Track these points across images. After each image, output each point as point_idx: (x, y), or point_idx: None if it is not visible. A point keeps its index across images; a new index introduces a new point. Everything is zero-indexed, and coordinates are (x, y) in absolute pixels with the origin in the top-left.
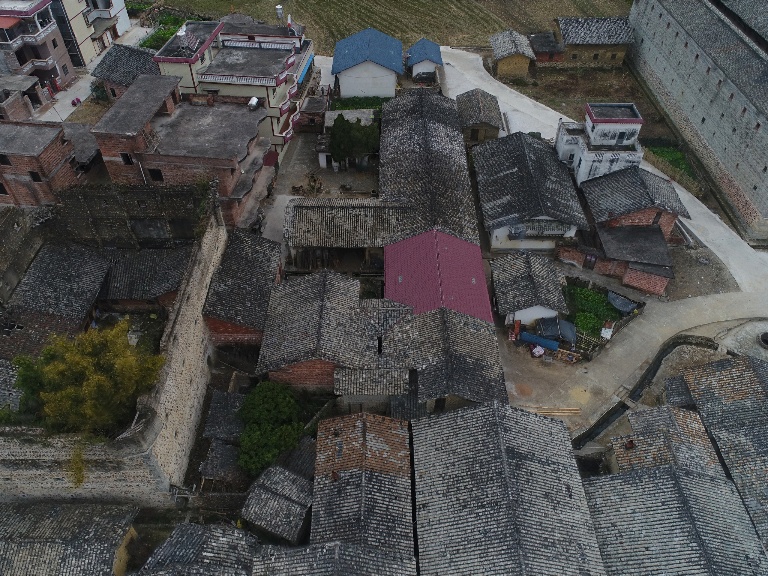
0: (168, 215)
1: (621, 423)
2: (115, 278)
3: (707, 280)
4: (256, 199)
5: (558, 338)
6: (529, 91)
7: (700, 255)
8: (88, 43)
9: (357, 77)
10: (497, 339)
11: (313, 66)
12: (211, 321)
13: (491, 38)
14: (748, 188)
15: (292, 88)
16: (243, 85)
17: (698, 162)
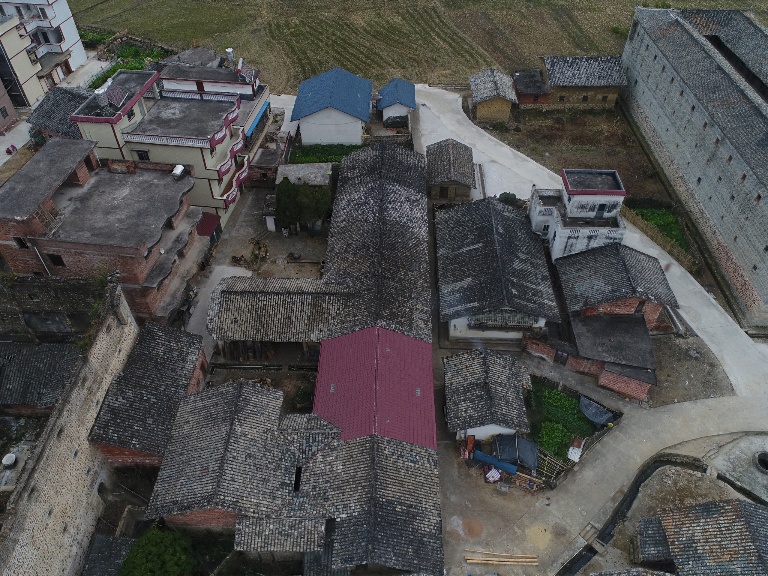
0: (66, 309)
1: (586, 574)
2: (8, 378)
3: (697, 379)
4: (182, 278)
5: (516, 462)
6: (510, 138)
7: (690, 346)
8: (33, 81)
9: (319, 124)
10: (447, 457)
11: (270, 112)
12: (103, 444)
13: (471, 77)
14: (747, 266)
15: (236, 145)
16: (174, 146)
17: (693, 226)
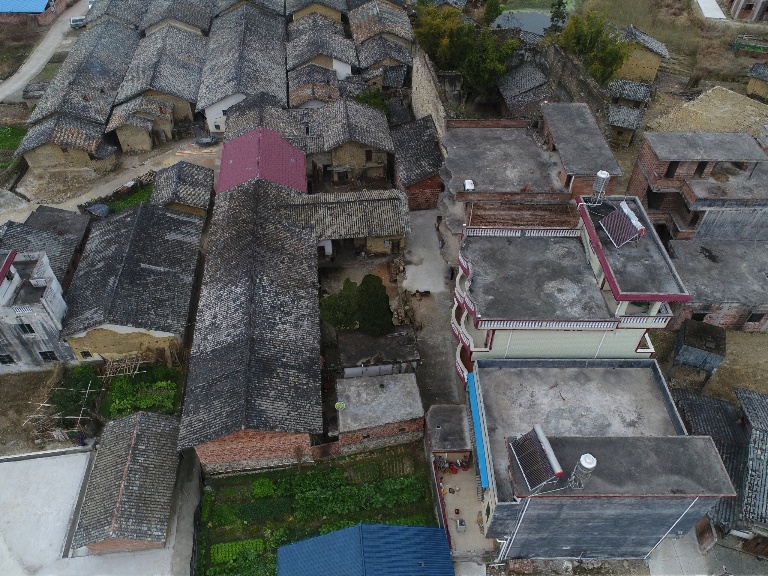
0: None
1: None
2: None
3: None
4: None
5: None
6: None
7: None
8: None
9: None
10: None
11: None
12: None
13: None
14: None
15: None
16: None
17: None
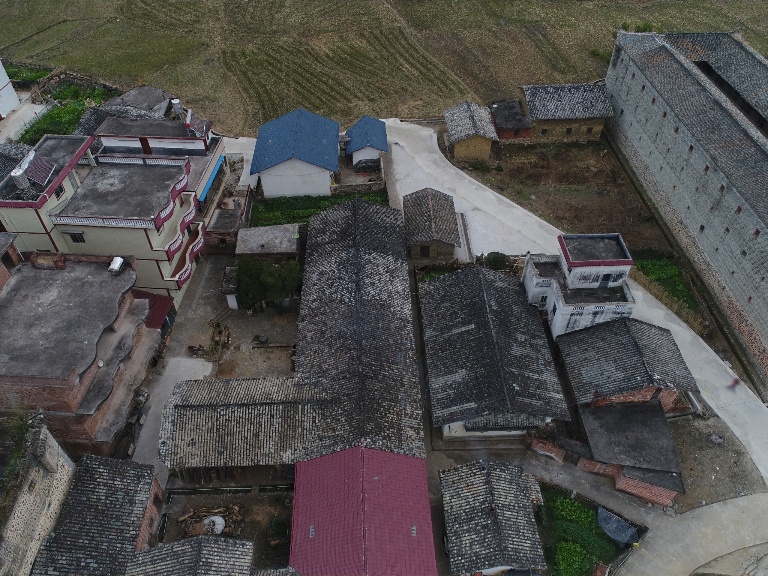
0: None
1: None
2: None
3: (723, 472)
4: (128, 388)
5: None
6: (492, 179)
7: (711, 430)
8: None
9: (282, 175)
10: None
11: (226, 166)
12: None
13: (446, 112)
14: (766, 332)
15: (187, 215)
16: (113, 227)
17: (697, 278)
